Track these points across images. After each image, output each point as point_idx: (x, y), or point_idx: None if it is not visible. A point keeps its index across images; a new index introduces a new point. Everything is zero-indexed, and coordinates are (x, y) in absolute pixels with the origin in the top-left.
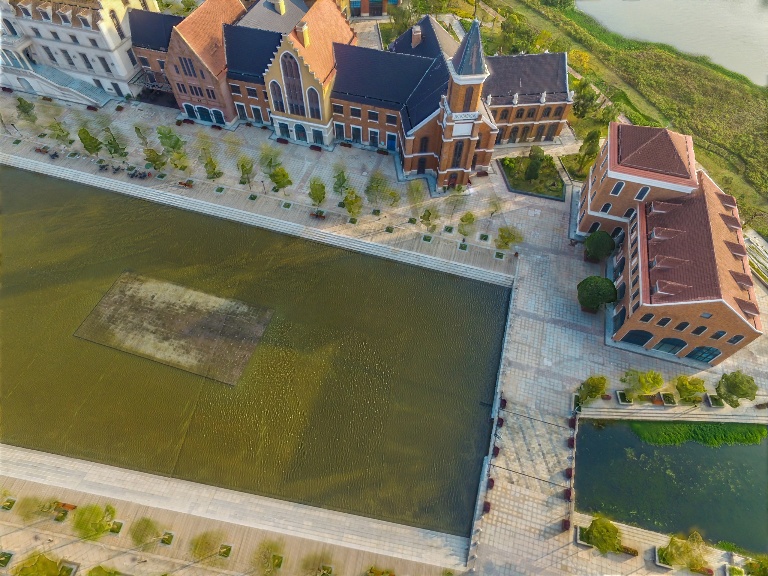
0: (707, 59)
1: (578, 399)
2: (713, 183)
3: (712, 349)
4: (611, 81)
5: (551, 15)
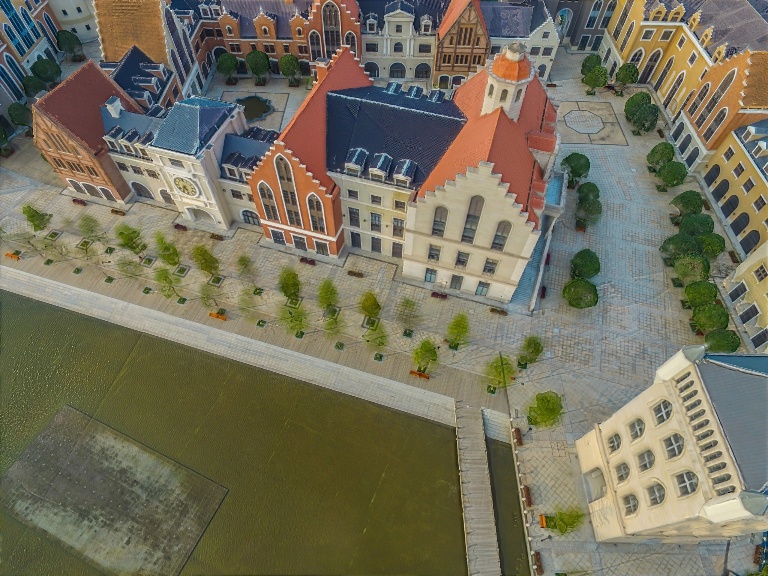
0: None
1: None
2: None
3: None
4: None
5: None
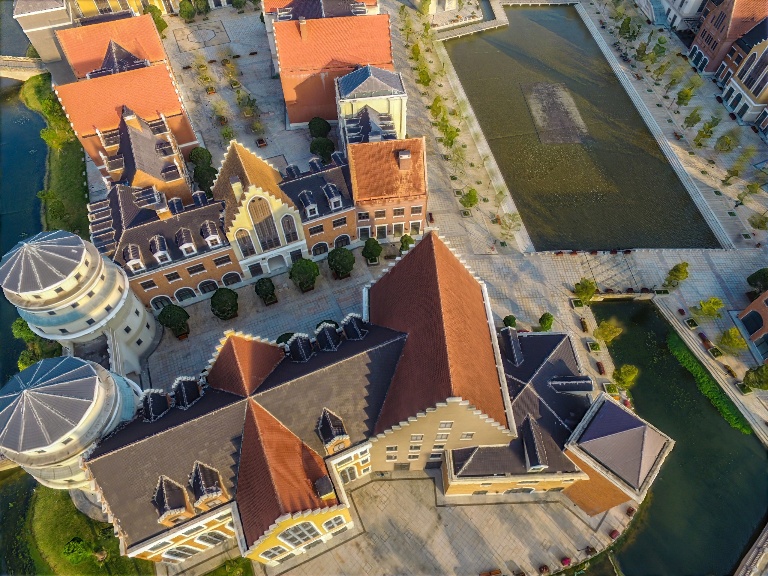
0: None
1: (665, 291)
2: None
3: None
4: None
5: None
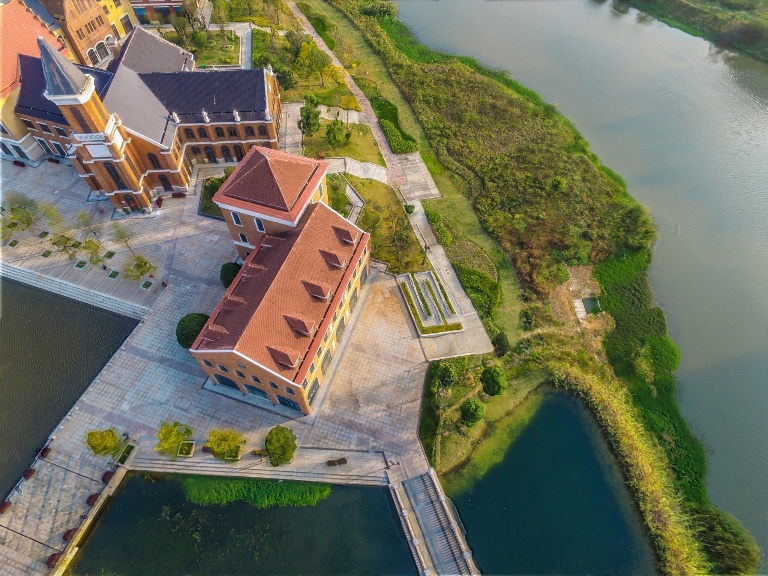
0: (506, 74)
1: (127, 450)
2: (338, 215)
3: (287, 398)
4: (389, 96)
5: (363, 25)
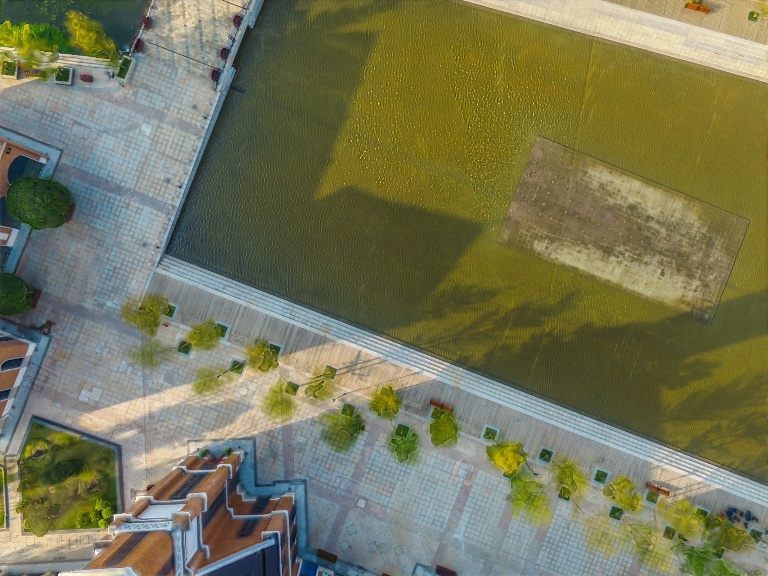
0: None
1: (122, 72)
2: None
3: None
4: None
5: None
